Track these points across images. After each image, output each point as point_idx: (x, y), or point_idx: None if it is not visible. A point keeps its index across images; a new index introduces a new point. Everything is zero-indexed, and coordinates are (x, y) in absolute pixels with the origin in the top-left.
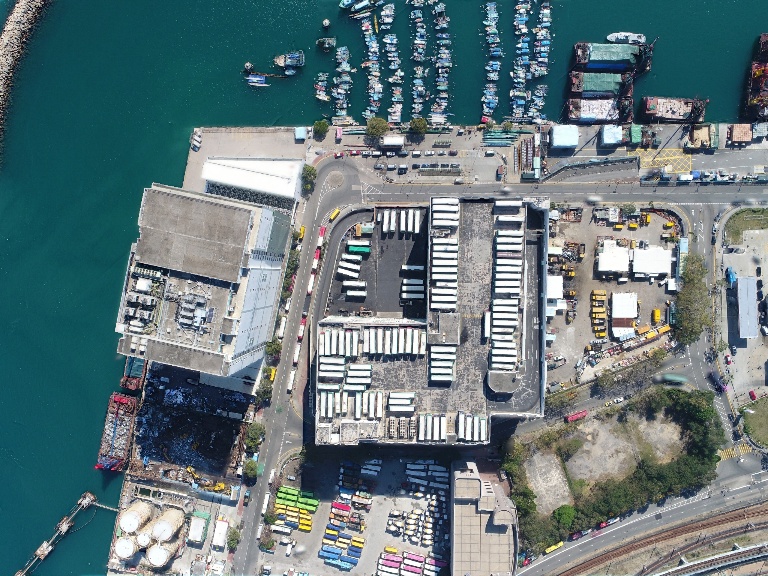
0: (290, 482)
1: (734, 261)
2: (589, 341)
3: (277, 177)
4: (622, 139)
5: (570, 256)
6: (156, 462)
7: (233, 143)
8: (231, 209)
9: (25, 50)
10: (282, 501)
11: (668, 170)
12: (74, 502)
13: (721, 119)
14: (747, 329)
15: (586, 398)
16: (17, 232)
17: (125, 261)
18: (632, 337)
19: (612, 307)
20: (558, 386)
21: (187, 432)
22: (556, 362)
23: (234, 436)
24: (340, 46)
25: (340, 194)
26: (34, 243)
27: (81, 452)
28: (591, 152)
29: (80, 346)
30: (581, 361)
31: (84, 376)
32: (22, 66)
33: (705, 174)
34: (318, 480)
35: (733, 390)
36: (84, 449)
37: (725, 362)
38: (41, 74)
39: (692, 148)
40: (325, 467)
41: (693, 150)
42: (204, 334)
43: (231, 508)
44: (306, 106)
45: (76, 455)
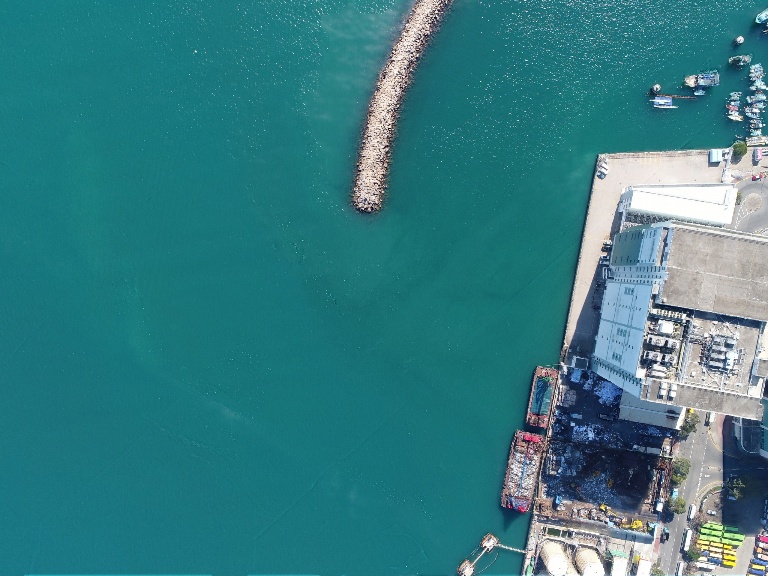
0: (710, 517)
1: None
2: None
3: (713, 204)
4: None
5: None
6: (567, 501)
7: (641, 169)
8: (766, 245)
9: (411, 80)
10: (706, 537)
11: None
12: (475, 545)
13: None
14: None
15: None
16: (407, 269)
17: (525, 295)
18: None
19: None
20: None
21: (598, 469)
22: None
23: (651, 472)
24: (754, 63)
25: (758, 217)
26: (426, 280)
27: (481, 493)
28: None
29: (478, 384)
30: None
31: (482, 415)
32: (408, 97)
33: None
34: (740, 514)
35: None
36: (484, 490)
37: None
38: (425, 104)
39: None
40: (747, 500)
41: None
42: (731, 376)
43: (646, 546)
44: (716, 127)
45: (474, 496)
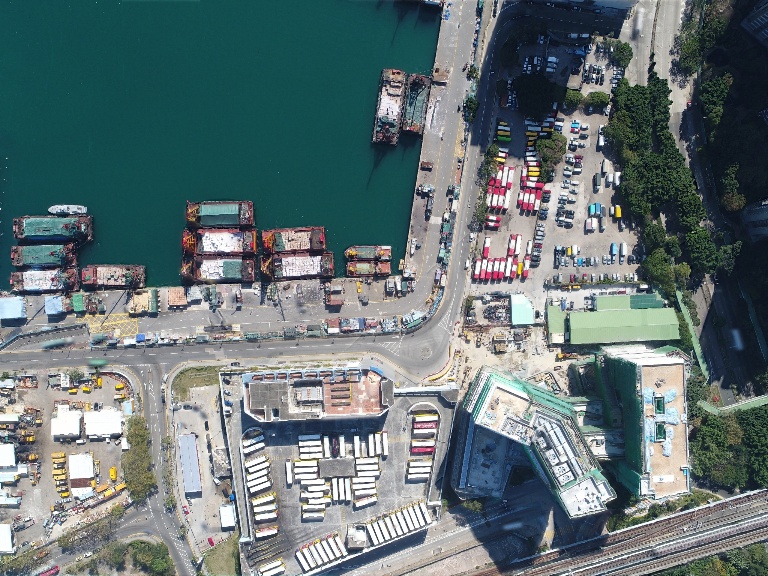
0: None
1: (184, 417)
2: (55, 501)
3: None
4: (67, 308)
5: (29, 421)
6: None
7: None
8: None
9: None
10: None
11: (116, 334)
12: None
13: (161, 284)
14: (191, 483)
15: (58, 555)
16: None
17: None
18: (91, 496)
19: (69, 469)
20: (26, 546)
21: None
22: (26, 523)
23: None
24: None
25: None
26: None
27: None
28: (43, 320)
29: None
30: (48, 521)
31: None
32: None
33: (145, 338)
34: None
35: (194, 538)
36: None
37: (184, 512)
38: None
39: (135, 313)
40: None
41: (138, 314)
42: None
43: None
44: None
45: None
